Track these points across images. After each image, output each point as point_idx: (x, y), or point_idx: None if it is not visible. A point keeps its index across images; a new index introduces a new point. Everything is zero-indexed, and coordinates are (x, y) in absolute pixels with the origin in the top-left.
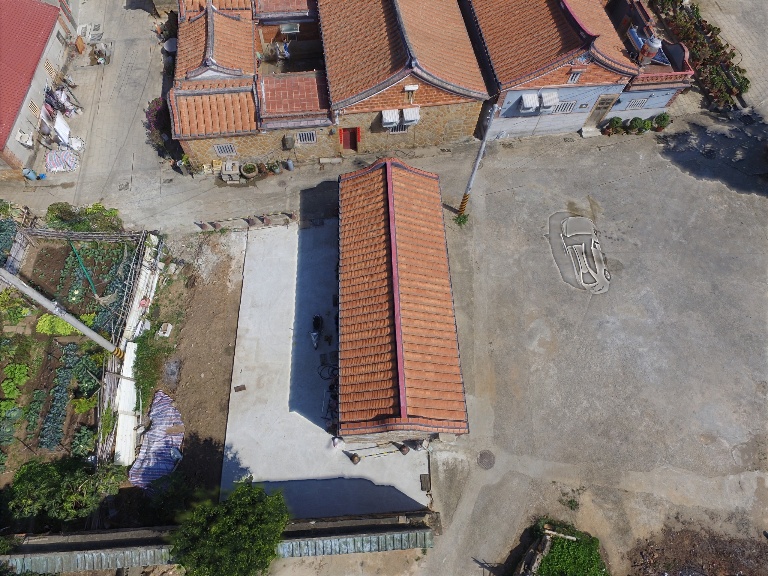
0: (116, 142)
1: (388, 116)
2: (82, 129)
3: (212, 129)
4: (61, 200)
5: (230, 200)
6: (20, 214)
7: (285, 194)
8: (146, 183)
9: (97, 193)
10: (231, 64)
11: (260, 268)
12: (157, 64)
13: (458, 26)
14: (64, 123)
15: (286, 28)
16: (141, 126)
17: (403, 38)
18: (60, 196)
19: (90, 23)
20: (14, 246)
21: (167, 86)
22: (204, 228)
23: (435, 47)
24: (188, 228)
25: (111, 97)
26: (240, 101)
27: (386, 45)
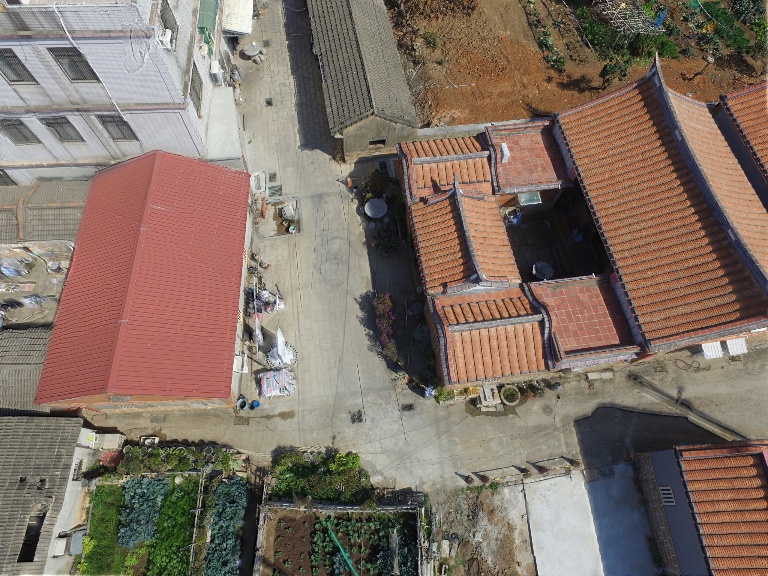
0: (333, 349)
1: (709, 350)
2: (288, 330)
3: (492, 371)
4: (284, 439)
5: (491, 437)
6: (242, 466)
7: (556, 427)
8: (382, 411)
9: (326, 427)
10: (495, 272)
11: (552, 544)
12: (356, 231)
13: (760, 211)
14: (282, 339)
15: (526, 198)
16: (357, 324)
17: (756, 271)
18: (281, 432)
19: (263, 170)
20: (258, 533)
21: (375, 263)
22: (471, 483)
23: (761, 258)
24: (450, 482)
25: (312, 281)
26: (525, 333)
27: (716, 267)
